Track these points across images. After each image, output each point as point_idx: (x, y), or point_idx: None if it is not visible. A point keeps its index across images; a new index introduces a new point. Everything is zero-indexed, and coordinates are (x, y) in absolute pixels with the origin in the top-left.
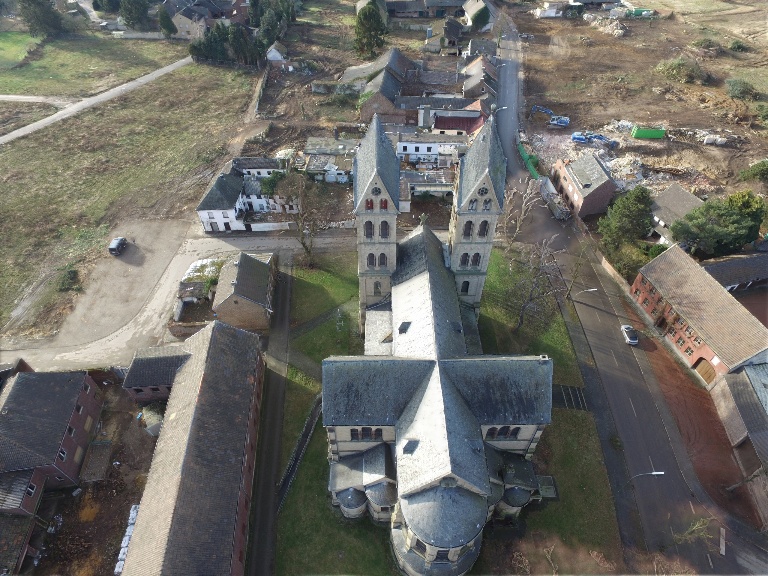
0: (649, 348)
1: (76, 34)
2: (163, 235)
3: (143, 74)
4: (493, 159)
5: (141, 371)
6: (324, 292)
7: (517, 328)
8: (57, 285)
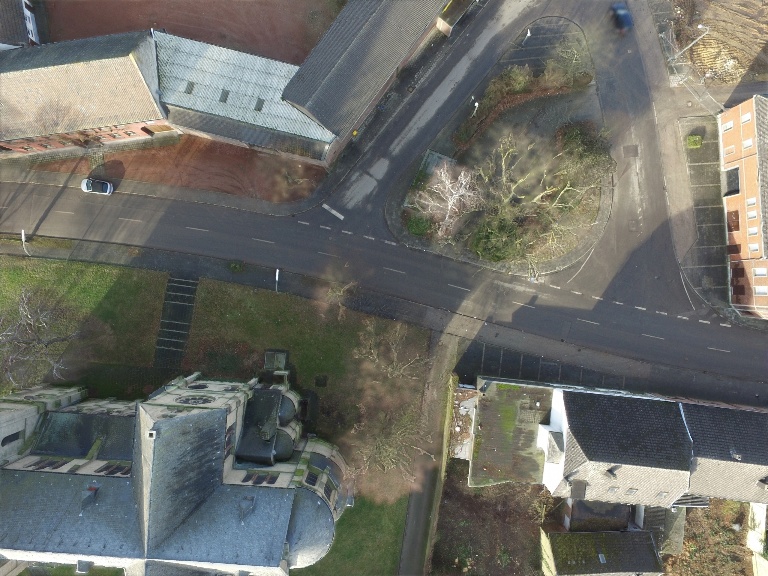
0: (119, 171)
1: None
2: None
3: None
4: None
5: None
6: None
7: (79, 337)
8: None
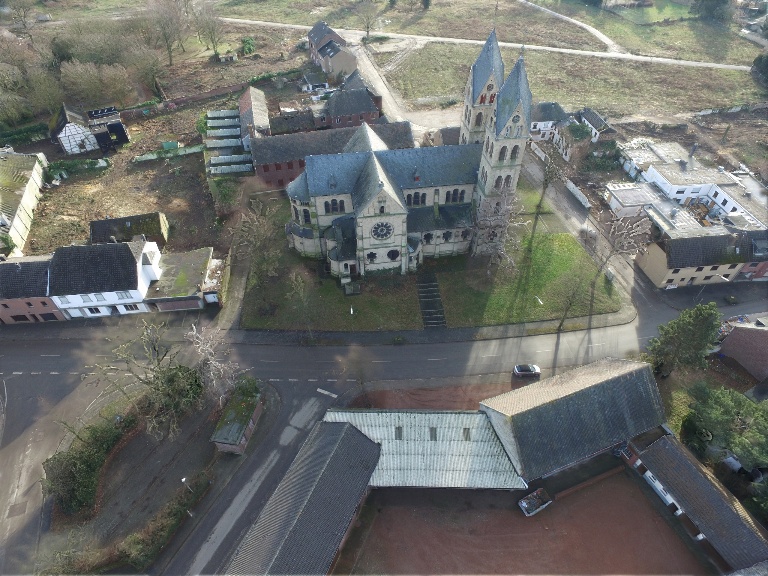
0: (516, 386)
1: (717, 21)
2: None
3: (694, 60)
4: (508, 90)
5: None
6: None
7: None
8: (444, 102)
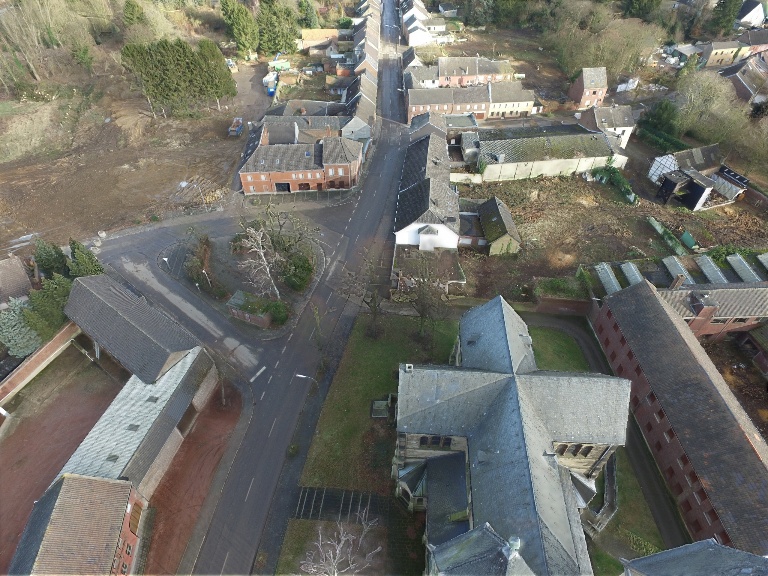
0: None
1: None
2: None
3: None
4: None
5: None
6: None
7: None
8: None
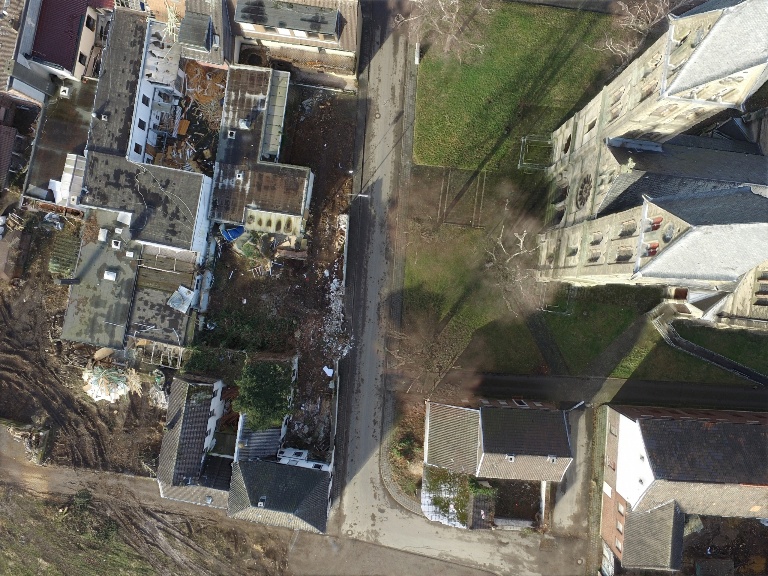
0: None
1: None
2: (328, 571)
3: None
4: None
5: (675, 555)
6: (491, 328)
7: None
8: None
